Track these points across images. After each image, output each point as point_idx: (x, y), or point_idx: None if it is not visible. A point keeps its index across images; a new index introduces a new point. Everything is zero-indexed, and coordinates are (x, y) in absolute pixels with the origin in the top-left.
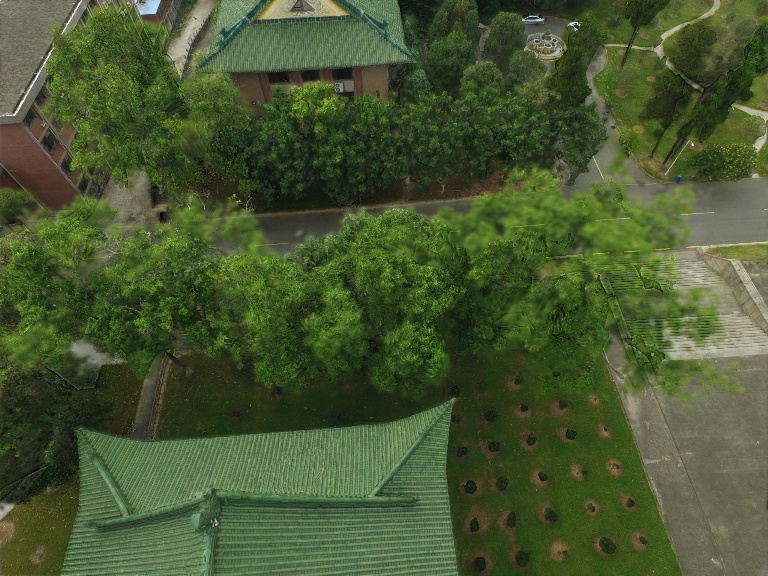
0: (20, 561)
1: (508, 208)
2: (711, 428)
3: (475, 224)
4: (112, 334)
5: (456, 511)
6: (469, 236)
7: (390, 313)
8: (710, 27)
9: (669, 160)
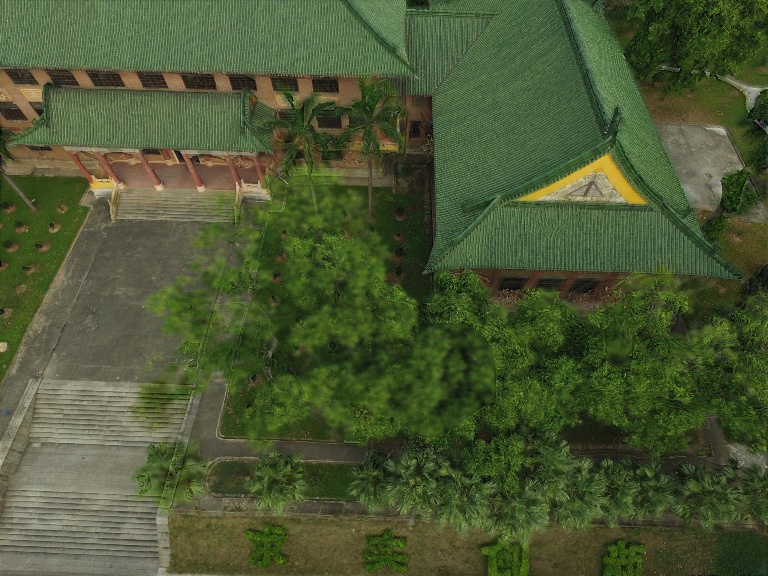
0: (732, 288)
1: None
2: (173, 321)
3: None
4: (767, 309)
5: (409, 286)
6: None
7: None
8: None
9: None
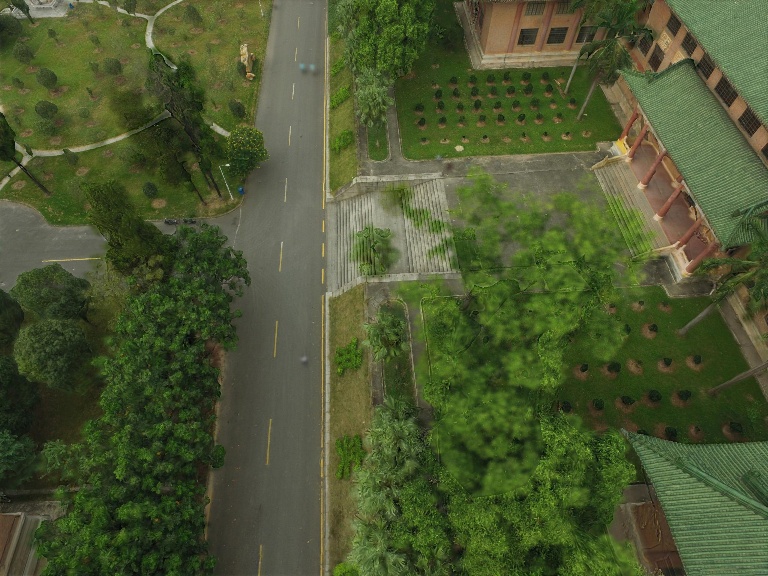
0: None
1: (245, 356)
2: (512, 240)
3: (263, 399)
4: None
5: (628, 451)
6: (281, 408)
7: (578, 495)
8: (18, 103)
9: (213, 191)
